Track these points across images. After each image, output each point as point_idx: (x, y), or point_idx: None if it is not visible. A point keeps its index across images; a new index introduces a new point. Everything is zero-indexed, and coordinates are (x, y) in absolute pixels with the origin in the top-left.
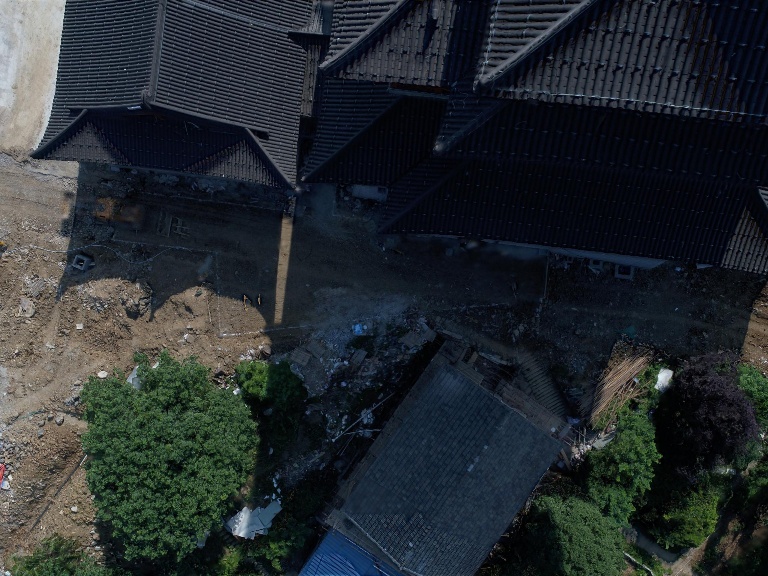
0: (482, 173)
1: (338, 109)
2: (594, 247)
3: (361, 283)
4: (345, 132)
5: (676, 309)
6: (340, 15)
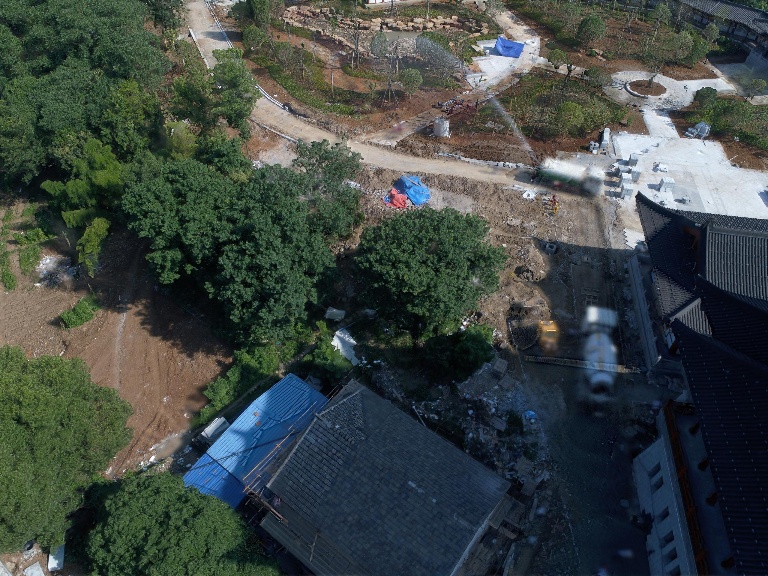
0: (764, 393)
1: (765, 305)
2: (728, 509)
3: (574, 421)
4: None
5: None
6: None
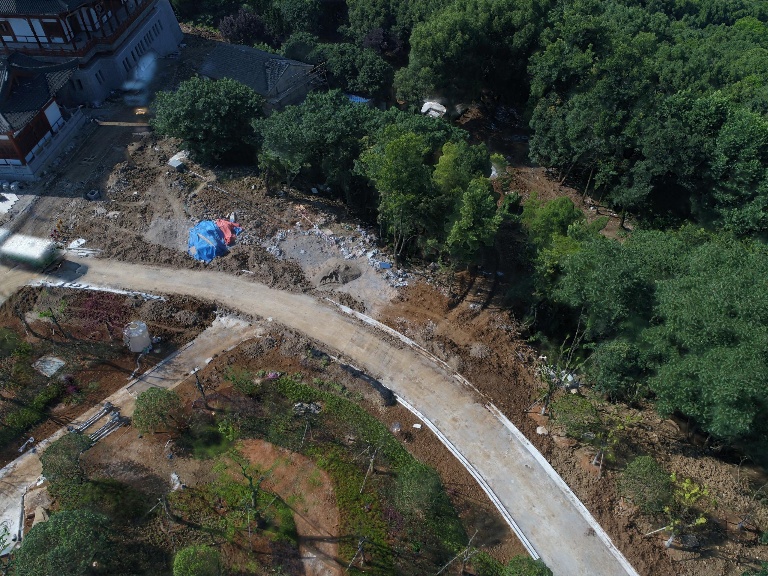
0: None
1: (43, 7)
2: None
3: (150, 101)
4: (54, 3)
5: (202, 48)
6: (2, 10)
